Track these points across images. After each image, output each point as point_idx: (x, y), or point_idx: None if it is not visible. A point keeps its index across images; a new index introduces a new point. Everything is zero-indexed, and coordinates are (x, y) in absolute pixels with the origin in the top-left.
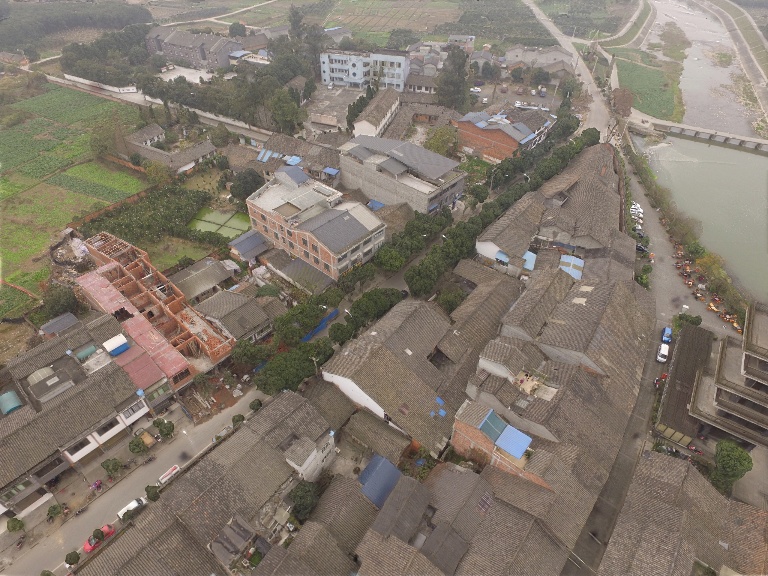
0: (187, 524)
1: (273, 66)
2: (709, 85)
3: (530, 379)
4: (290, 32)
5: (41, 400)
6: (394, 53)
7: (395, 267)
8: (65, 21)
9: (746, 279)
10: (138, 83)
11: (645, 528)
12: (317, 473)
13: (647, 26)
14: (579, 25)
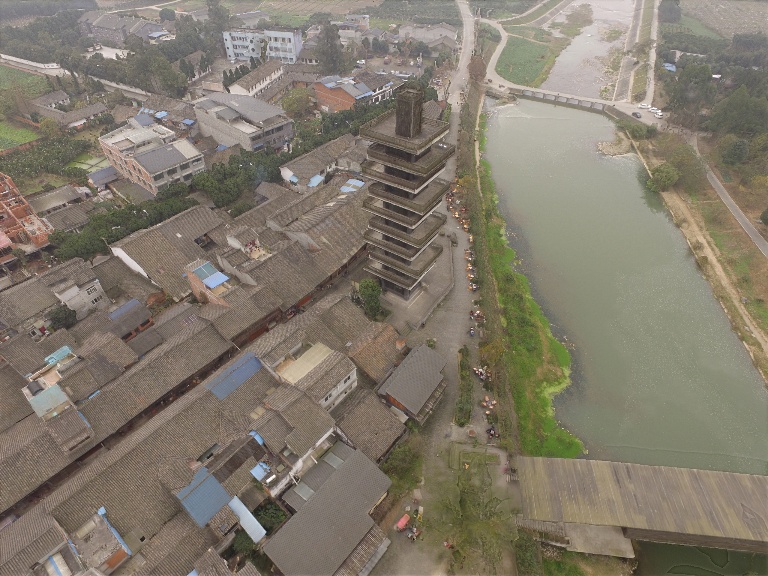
0: None
1: (171, 41)
2: (584, 57)
3: (257, 249)
4: (209, 15)
5: None
6: (286, 30)
7: (206, 187)
8: (14, 10)
9: (513, 201)
10: (56, 58)
11: (284, 327)
12: (87, 310)
13: (559, 7)
14: (491, 7)
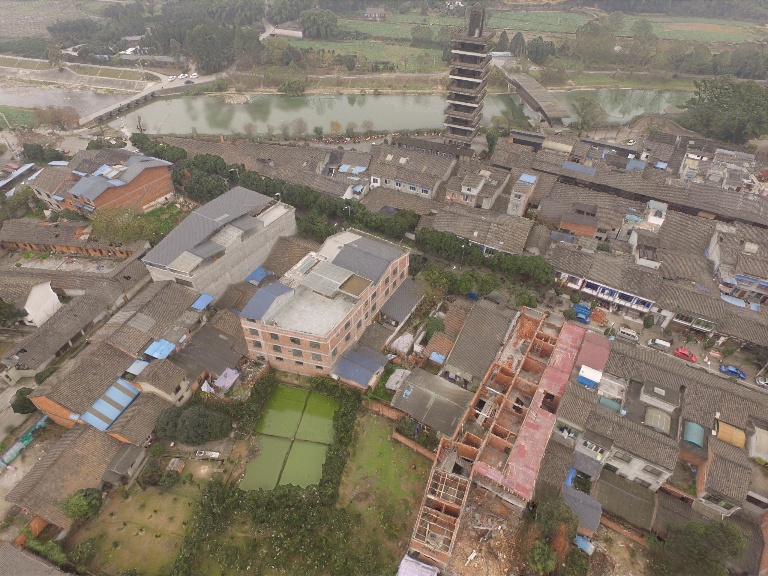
0: None
1: None
2: None
3: None
4: None
5: None
6: None
7: None
8: None
9: None
10: None
11: (537, 159)
12: None
13: None
14: None
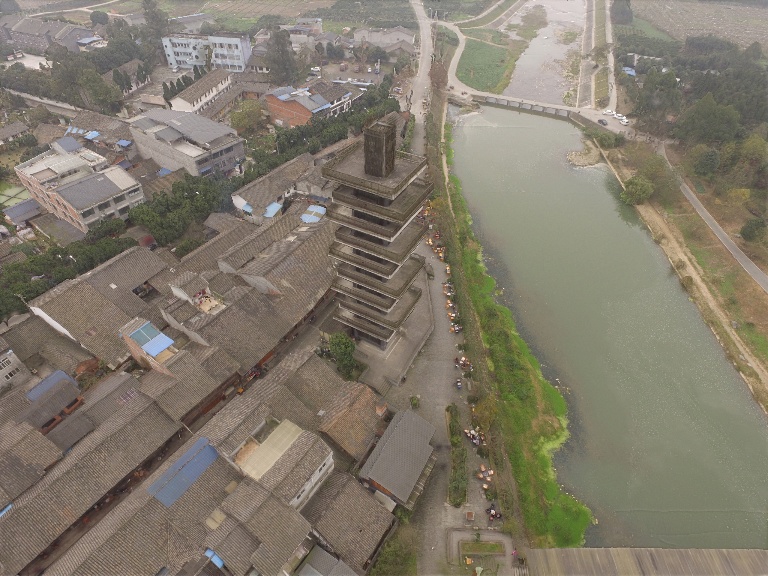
0: None
1: (102, 49)
2: (543, 60)
3: (208, 300)
4: (146, 19)
5: None
6: (232, 35)
7: (147, 221)
8: None
9: (487, 221)
10: None
11: None
12: None
13: (514, 9)
14: (446, 8)
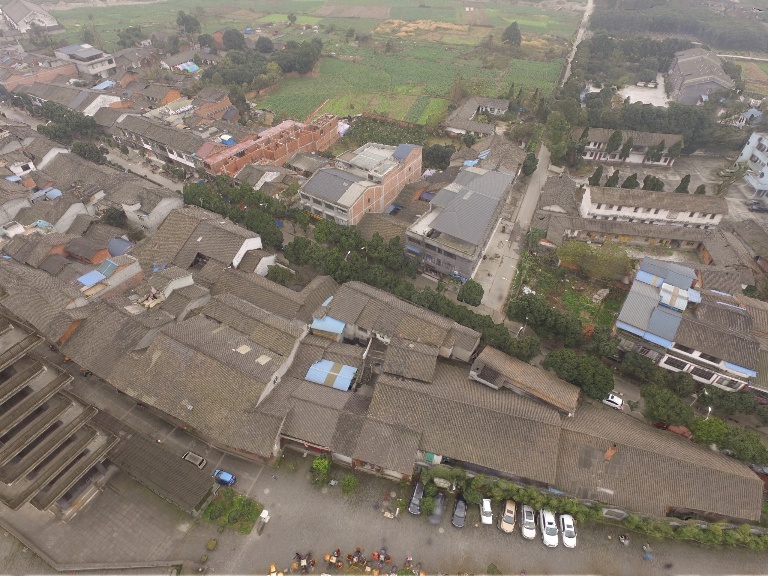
0: (106, 178)
1: (649, 107)
2: None
3: None
4: None
5: (193, 132)
6: None
7: None
8: (681, 26)
9: None
10: None
11: None
12: (137, 227)
13: None
14: None
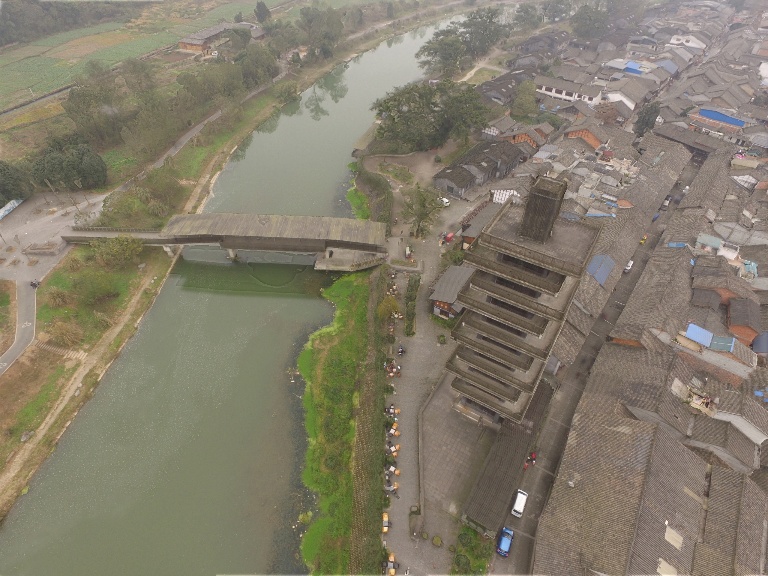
0: None
1: None
2: None
3: (702, 400)
4: None
5: None
6: None
7: None
8: None
9: None
10: None
11: None
12: None
13: None
14: None
